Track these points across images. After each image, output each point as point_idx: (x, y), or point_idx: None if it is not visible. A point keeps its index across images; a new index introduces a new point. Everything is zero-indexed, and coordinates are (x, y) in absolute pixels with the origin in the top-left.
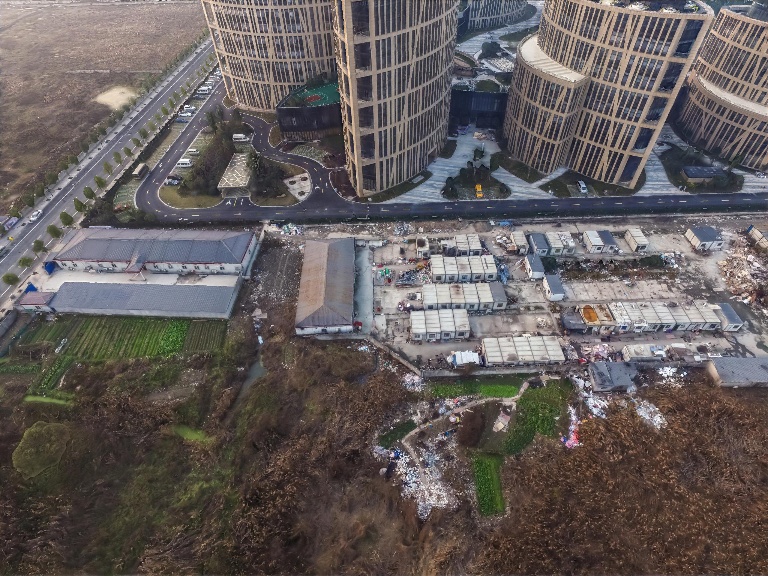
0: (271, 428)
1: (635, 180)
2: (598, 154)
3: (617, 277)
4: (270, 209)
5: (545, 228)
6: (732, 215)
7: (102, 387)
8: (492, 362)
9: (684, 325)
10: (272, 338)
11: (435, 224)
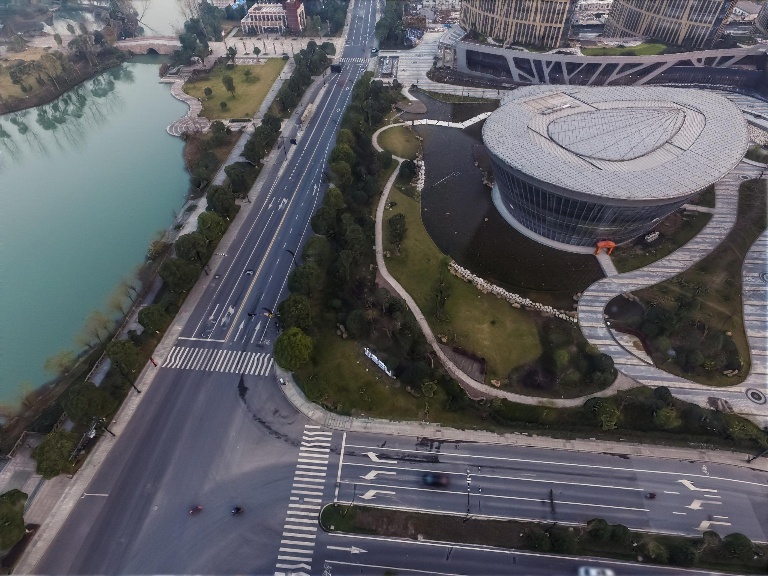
0: None
1: None
2: None
3: None
4: None
5: None
6: None
7: None
8: None
9: None
10: None
11: None
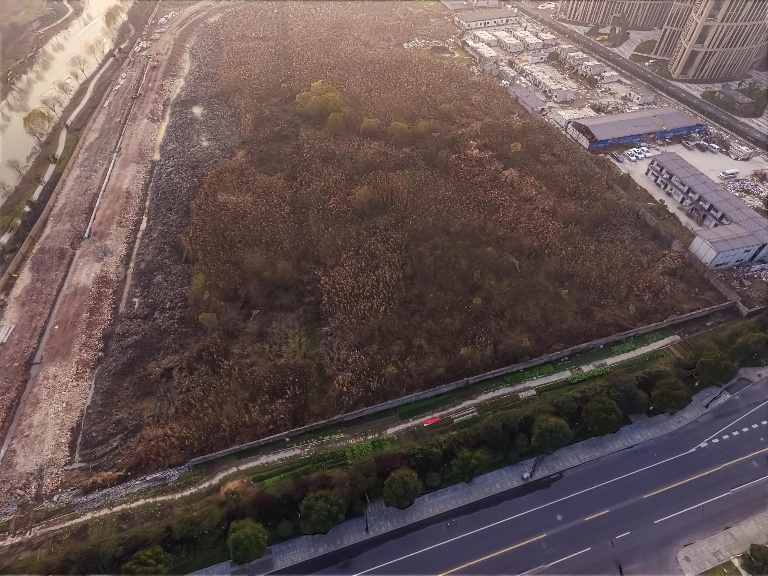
0: (411, 20)
1: (677, 70)
2: (678, 44)
3: (568, 76)
4: (523, 4)
5: (592, 59)
6: (694, 113)
7: (406, 1)
8: (471, 45)
9: (541, 83)
10: (449, 18)
11: (556, 33)
